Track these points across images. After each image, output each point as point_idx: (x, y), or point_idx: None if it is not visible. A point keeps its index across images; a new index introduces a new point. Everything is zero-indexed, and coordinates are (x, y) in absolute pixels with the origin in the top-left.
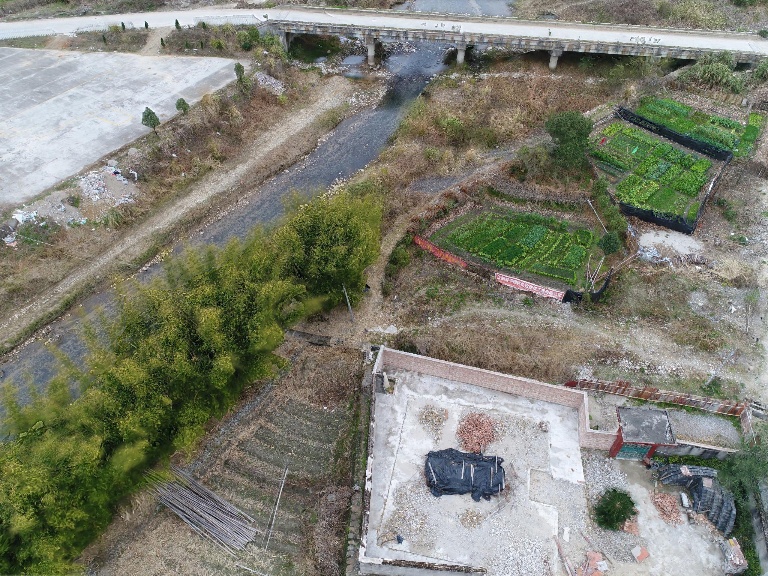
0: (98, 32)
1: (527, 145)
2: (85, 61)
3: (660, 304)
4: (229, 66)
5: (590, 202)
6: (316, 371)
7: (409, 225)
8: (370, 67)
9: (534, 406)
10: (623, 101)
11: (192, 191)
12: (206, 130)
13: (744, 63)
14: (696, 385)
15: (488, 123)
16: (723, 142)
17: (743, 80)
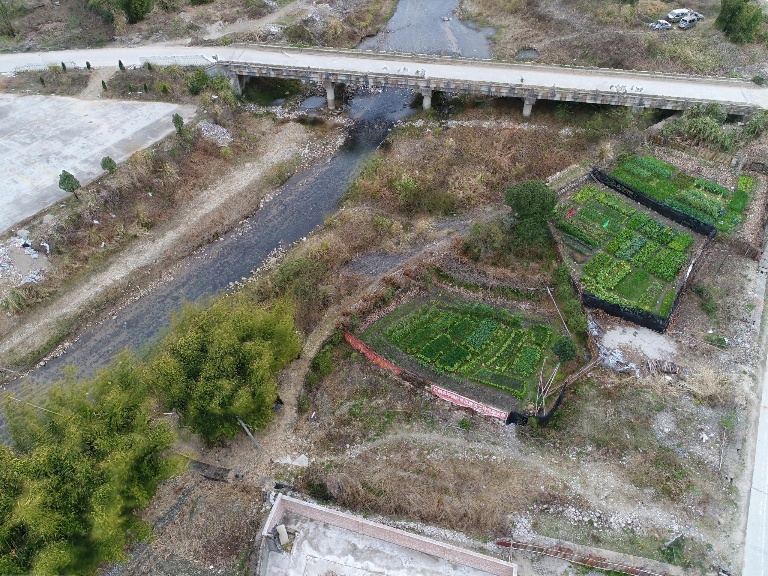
0: (38, 72)
1: (486, 215)
2: (18, 106)
3: (619, 430)
4: (173, 113)
5: (549, 291)
6: (207, 516)
7: (339, 320)
8: (330, 111)
9: (457, 574)
10: (598, 160)
11: (111, 265)
12: (136, 191)
13: (735, 115)
14: (654, 545)
15: (448, 184)
16: (707, 212)
17: (733, 135)
